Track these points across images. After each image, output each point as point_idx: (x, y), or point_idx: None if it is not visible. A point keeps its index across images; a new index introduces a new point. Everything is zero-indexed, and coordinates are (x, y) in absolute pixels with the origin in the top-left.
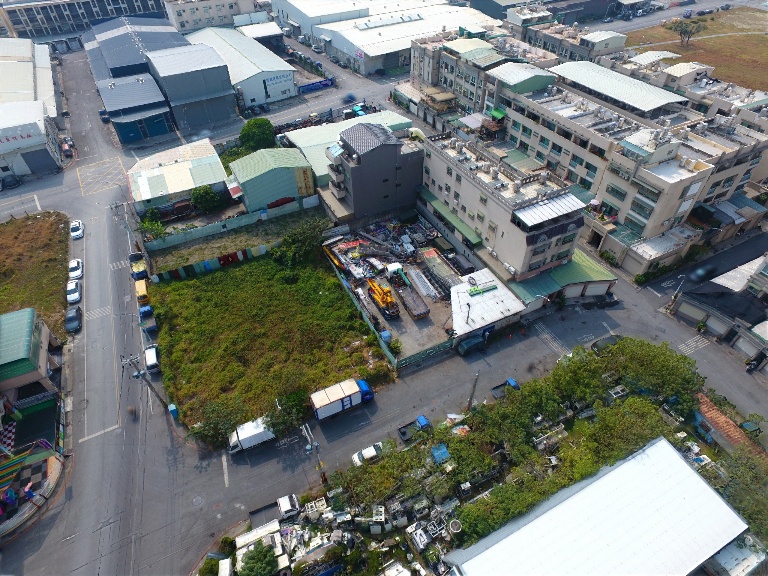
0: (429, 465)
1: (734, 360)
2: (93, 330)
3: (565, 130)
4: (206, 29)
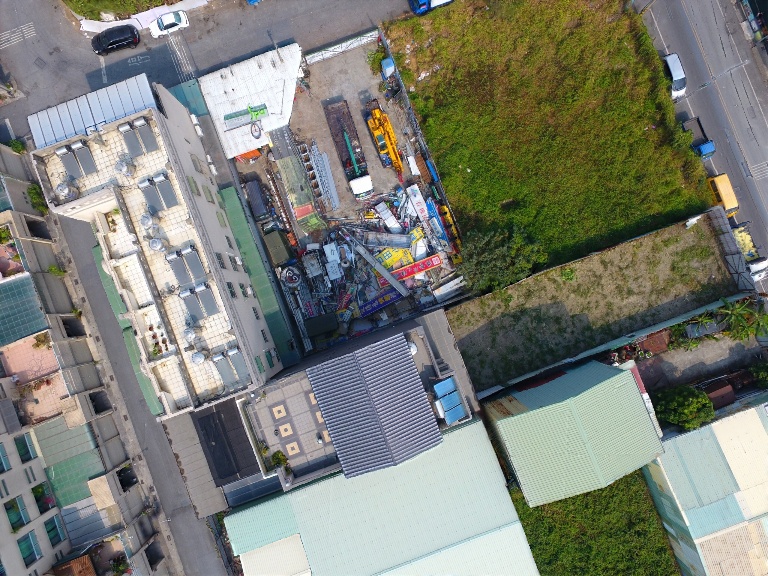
0: None
1: None
2: (763, 138)
3: None
4: None
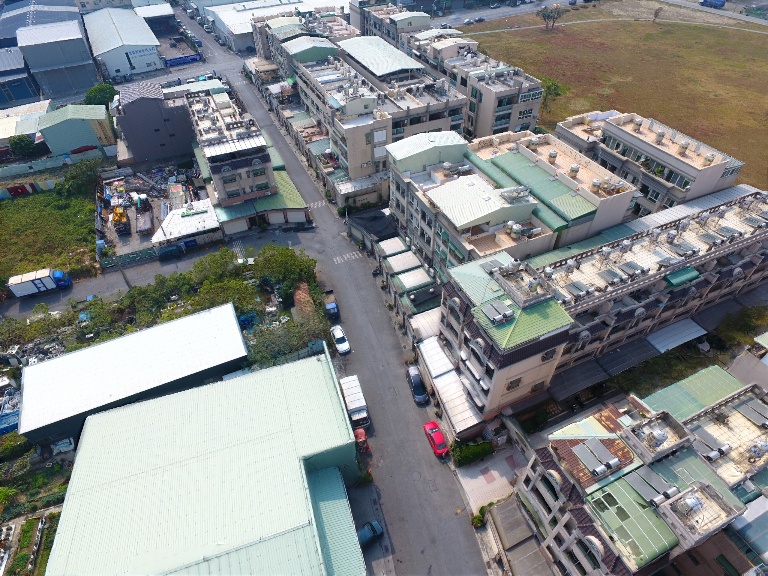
0: (76, 325)
1: (370, 268)
2: None
3: (315, 91)
4: (104, 9)
